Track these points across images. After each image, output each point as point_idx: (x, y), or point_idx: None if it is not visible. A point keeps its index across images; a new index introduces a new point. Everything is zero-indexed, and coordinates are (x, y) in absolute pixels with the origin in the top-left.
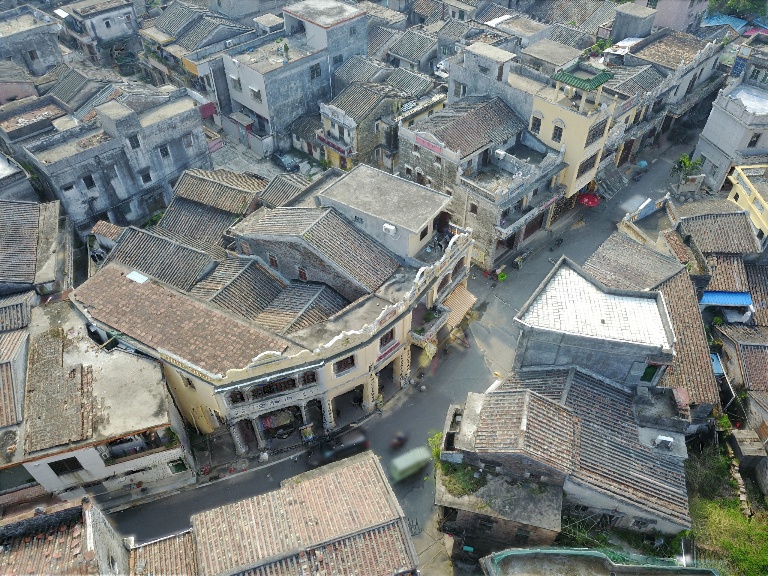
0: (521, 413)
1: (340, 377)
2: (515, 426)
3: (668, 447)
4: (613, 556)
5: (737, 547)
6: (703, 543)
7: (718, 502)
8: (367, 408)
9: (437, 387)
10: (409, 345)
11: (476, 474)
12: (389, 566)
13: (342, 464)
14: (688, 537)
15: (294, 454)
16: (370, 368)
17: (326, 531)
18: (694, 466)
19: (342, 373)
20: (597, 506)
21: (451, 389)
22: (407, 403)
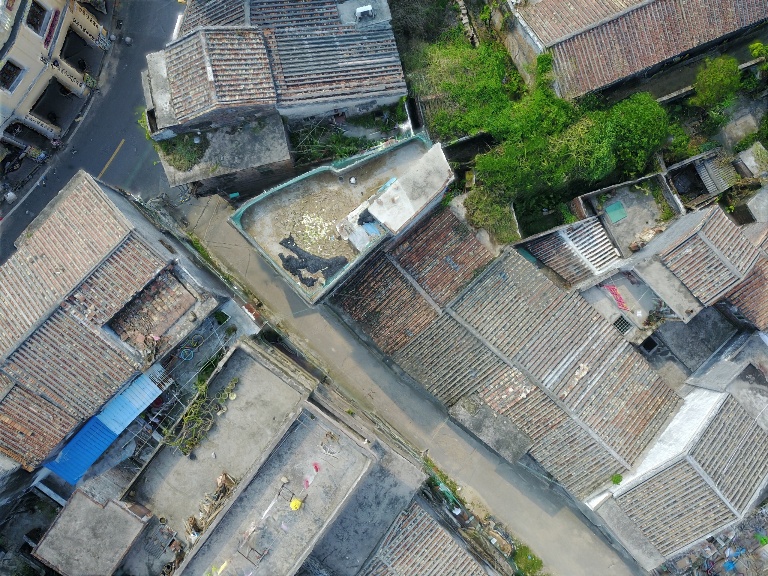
0: (203, 61)
1: (15, 90)
2: (203, 79)
3: (370, 15)
4: (349, 149)
5: (455, 84)
6: (426, 95)
7: (445, 35)
8: (81, 95)
9: (142, 31)
10: (74, 3)
11: (196, 139)
12: (146, 273)
13: (61, 198)
14: (412, 96)
15: (38, 179)
16: (43, 60)
17: (74, 274)
18: (415, 8)
19: (14, 84)
20: (320, 112)
21: (158, 26)
22: (120, 66)
